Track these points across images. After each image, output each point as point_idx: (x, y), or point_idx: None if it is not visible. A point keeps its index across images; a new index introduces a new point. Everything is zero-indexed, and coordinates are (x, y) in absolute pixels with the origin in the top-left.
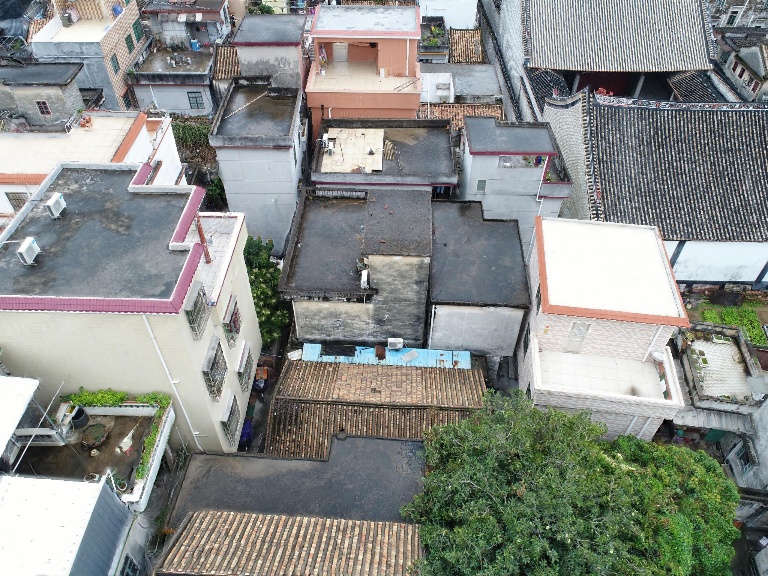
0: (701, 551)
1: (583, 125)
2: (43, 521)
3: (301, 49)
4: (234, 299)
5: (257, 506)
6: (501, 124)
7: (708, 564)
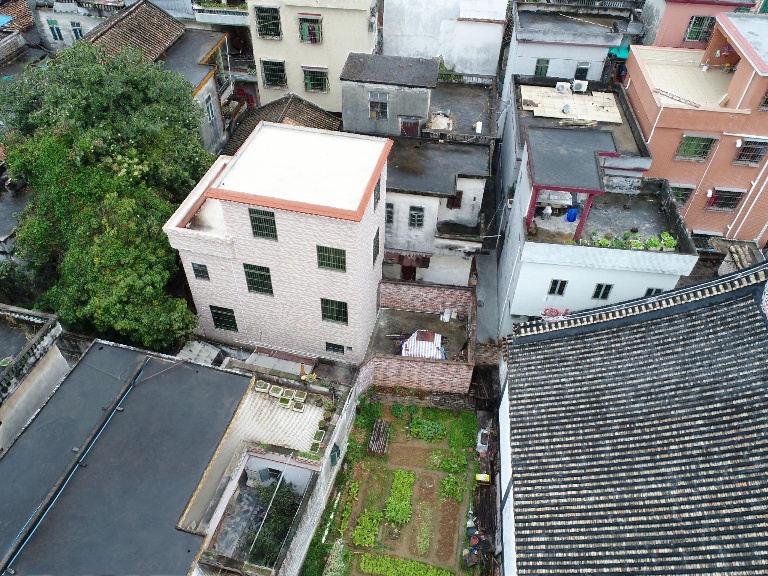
0: (72, 245)
1: None
2: None
3: (691, 20)
4: (317, 17)
5: (184, 47)
6: (598, 153)
7: (66, 256)
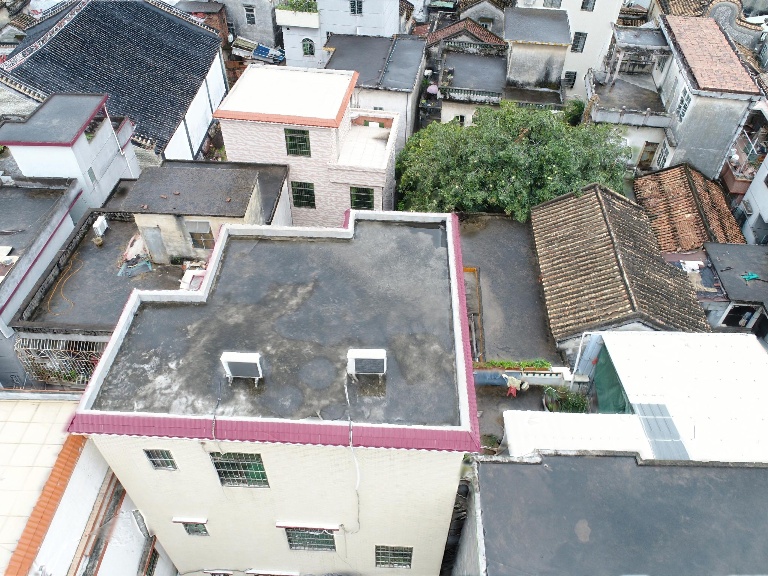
0: None
1: (30, 94)
2: (657, 359)
3: None
4: None
5: (530, 309)
6: None
7: None
